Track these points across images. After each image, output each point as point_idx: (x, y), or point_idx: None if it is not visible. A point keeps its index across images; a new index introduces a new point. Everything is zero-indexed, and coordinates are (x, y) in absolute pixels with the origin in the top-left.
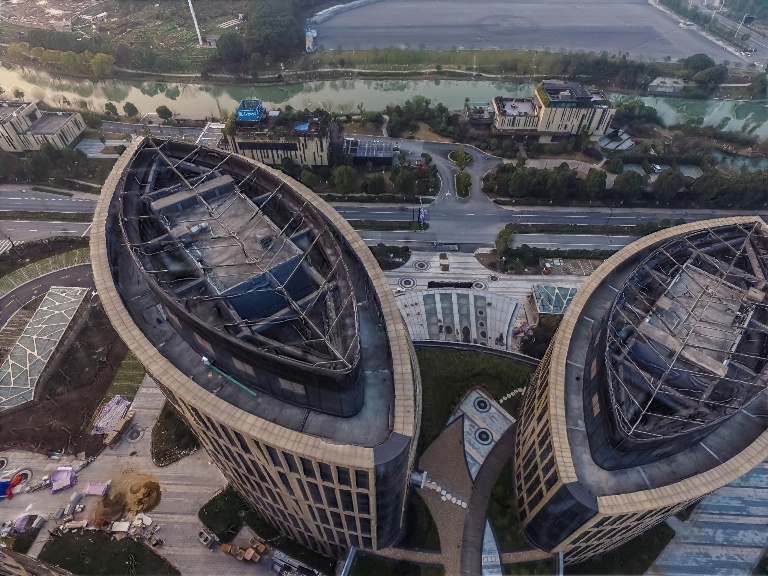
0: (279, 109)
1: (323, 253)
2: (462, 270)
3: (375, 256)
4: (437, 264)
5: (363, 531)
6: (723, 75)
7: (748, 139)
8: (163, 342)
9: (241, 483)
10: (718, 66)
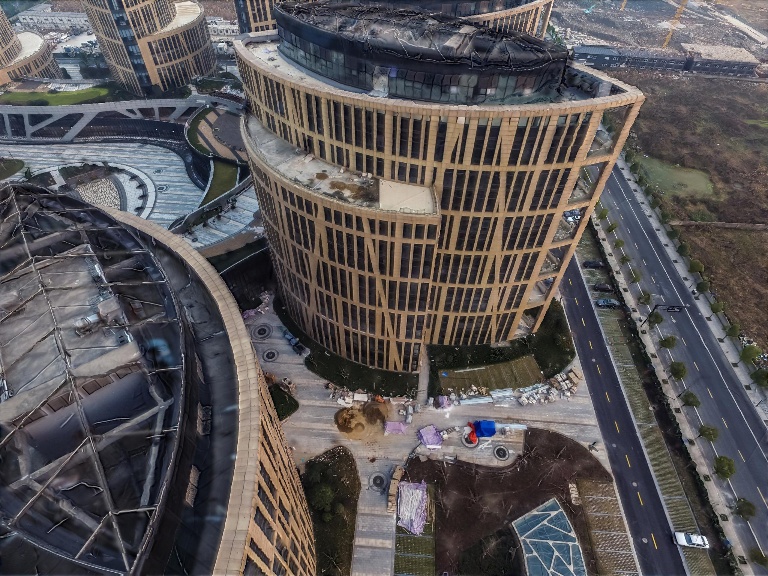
0: None
1: None
2: None
3: None
4: None
5: None
6: None
7: None
8: (188, 287)
9: None
10: None
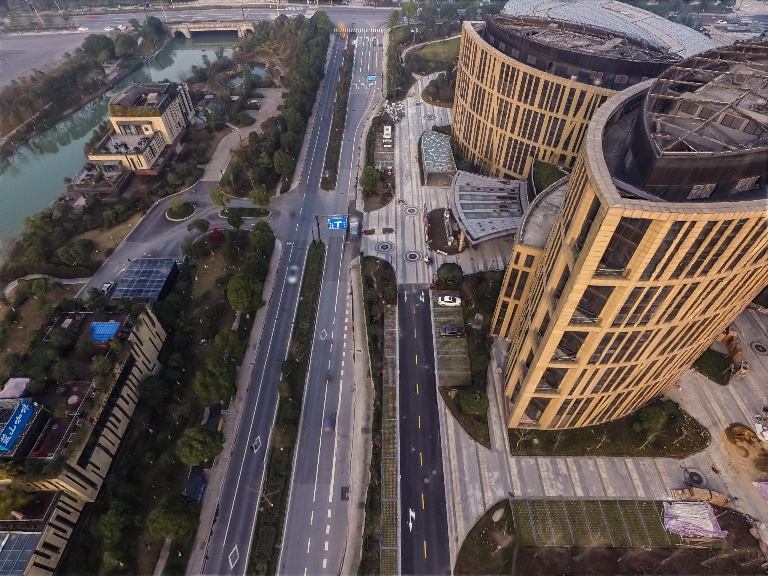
0: (1, 379)
1: (724, 63)
2: (390, 220)
3: (377, 279)
4: (382, 236)
5: None
6: (133, 39)
7: (228, 61)
8: None
9: None
10: (120, 35)
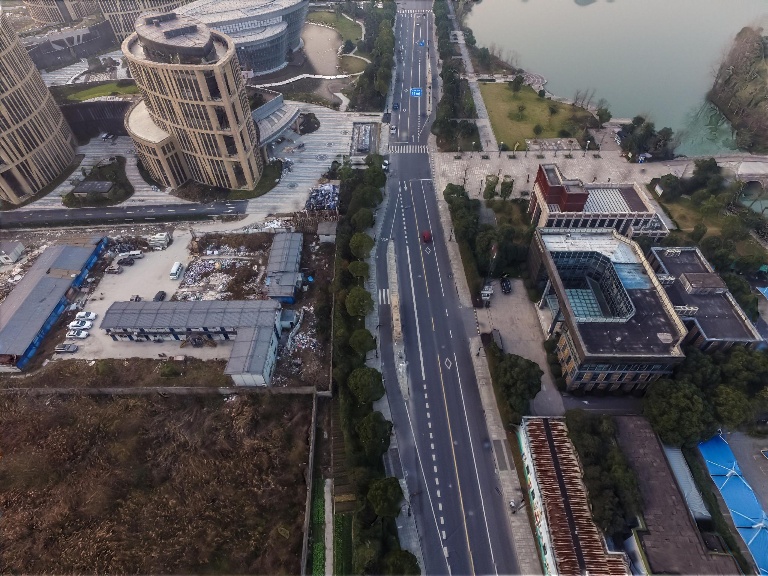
0: None
1: None
2: None
3: None
4: None
5: (53, 3)
6: None
7: None
8: None
9: (31, 3)
10: None
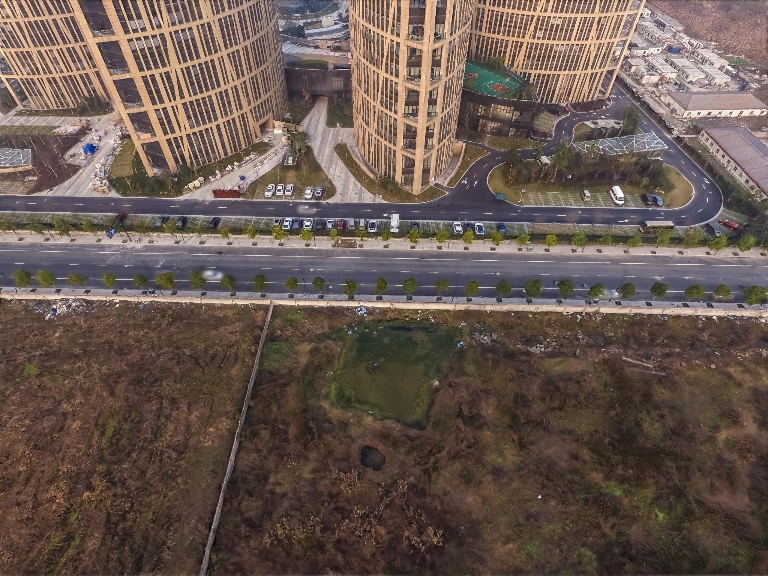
0: None
1: None
2: None
3: None
4: None
5: None
6: None
7: None
8: None
9: None
10: None
